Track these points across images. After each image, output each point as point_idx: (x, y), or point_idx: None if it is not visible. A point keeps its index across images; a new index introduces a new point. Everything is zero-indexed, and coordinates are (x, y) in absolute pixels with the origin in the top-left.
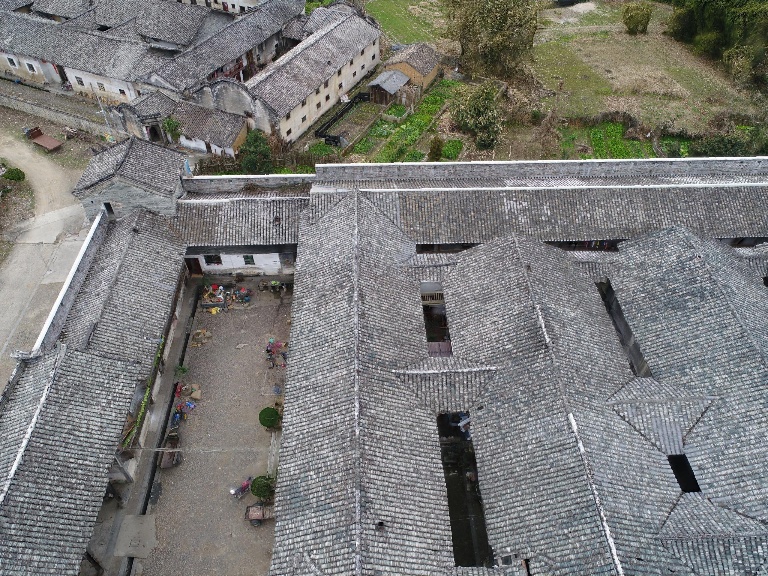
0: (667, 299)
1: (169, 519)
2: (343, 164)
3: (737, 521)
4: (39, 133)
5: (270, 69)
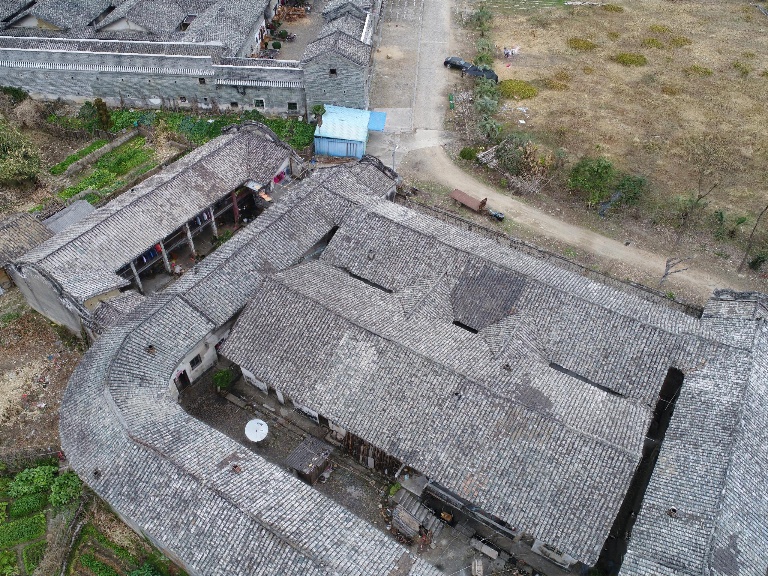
0: (75, 7)
1: None
2: (192, 56)
3: None
4: (481, 207)
5: (210, 181)
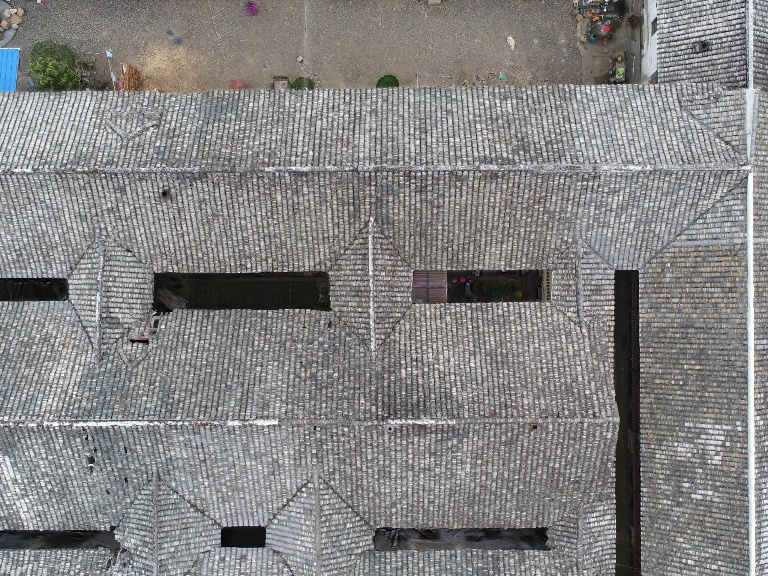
0: None
1: (284, 1)
2: None
3: (175, 568)
4: None
5: None
